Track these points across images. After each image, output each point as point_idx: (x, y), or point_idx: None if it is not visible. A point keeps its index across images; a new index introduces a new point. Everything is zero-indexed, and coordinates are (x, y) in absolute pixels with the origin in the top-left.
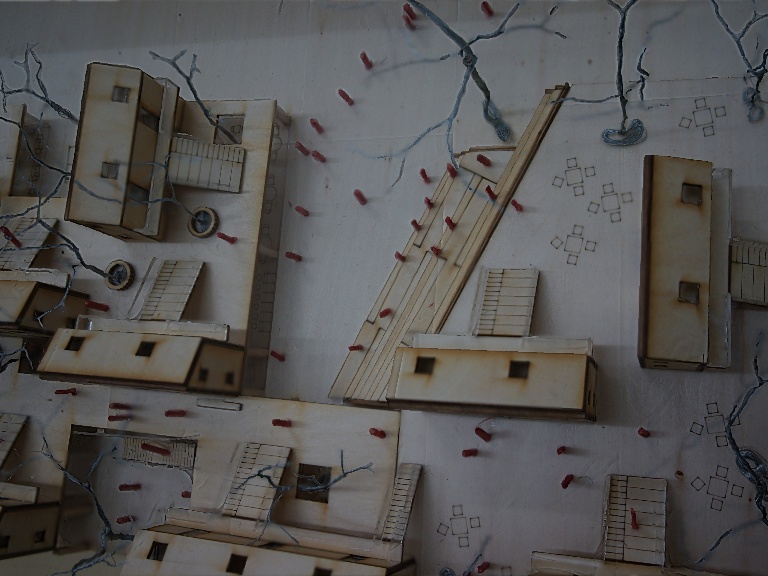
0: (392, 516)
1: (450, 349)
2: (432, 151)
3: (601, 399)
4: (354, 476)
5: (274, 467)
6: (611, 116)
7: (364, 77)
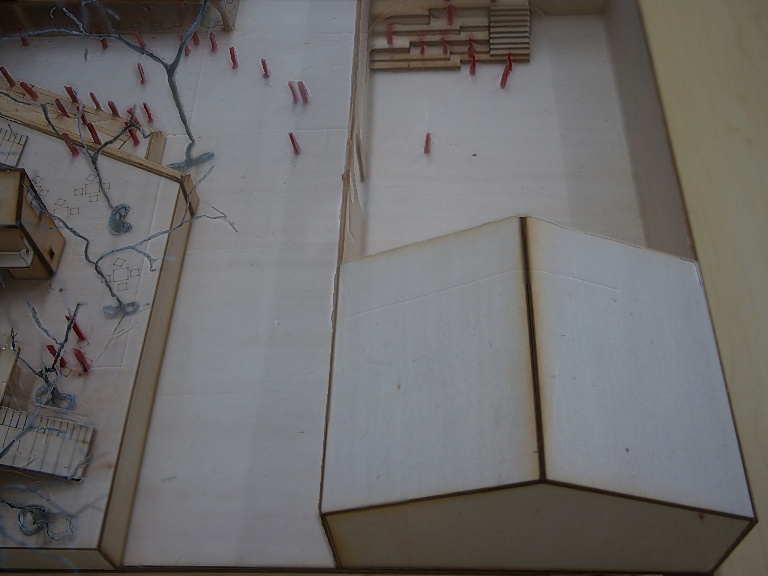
0: None
1: None
2: (176, 122)
3: None
4: None
5: None
6: (141, 210)
7: (256, 74)
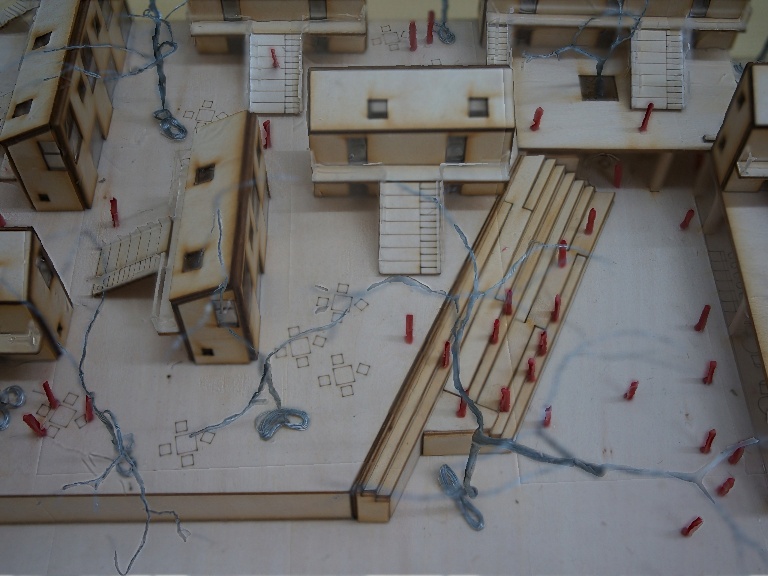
0: (503, 49)
1: (455, 128)
2: None
3: (310, 170)
4: (556, 96)
5: (643, 85)
6: (299, 447)
7: (675, 571)
